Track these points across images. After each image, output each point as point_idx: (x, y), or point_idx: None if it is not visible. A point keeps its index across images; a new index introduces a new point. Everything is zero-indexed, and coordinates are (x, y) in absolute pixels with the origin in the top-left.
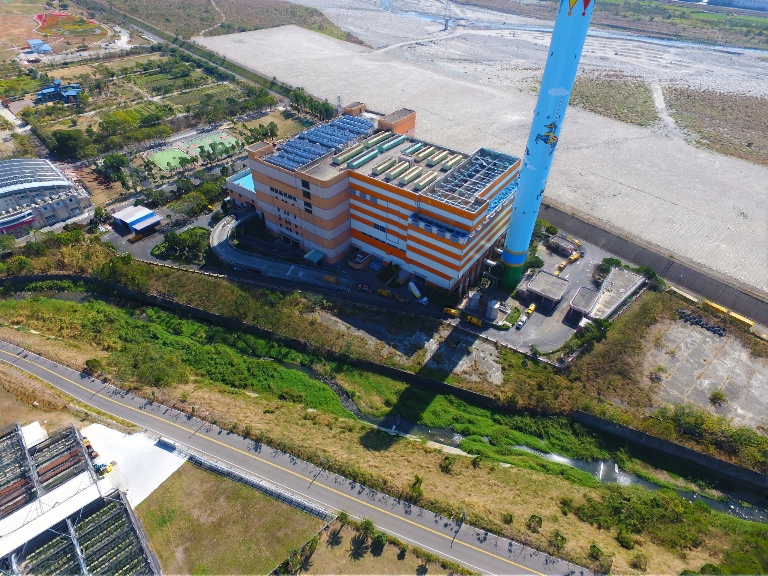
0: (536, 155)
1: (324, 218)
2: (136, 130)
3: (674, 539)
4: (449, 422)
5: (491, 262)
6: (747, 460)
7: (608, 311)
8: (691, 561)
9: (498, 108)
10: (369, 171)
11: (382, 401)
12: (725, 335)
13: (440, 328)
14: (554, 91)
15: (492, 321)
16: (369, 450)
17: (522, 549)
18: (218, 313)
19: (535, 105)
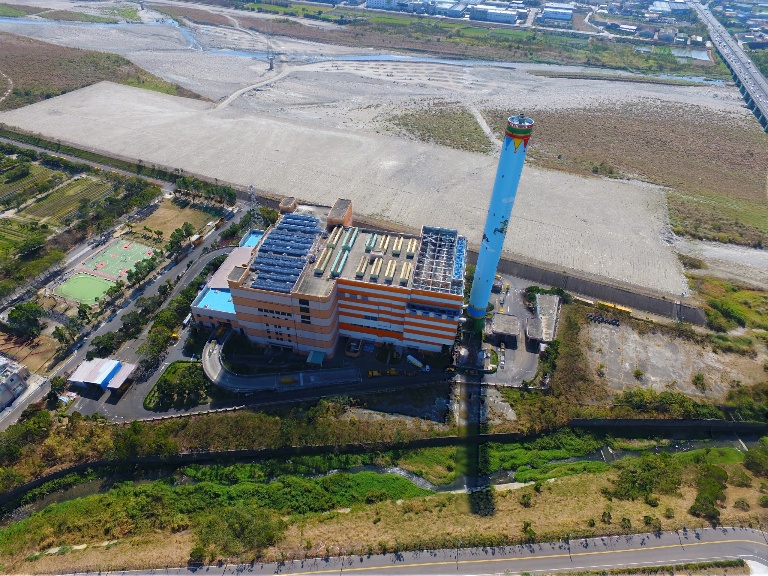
0: (495, 242)
1: (325, 325)
2: (19, 264)
3: (672, 487)
4: (499, 464)
5: (461, 319)
6: (676, 414)
7: (552, 332)
8: (685, 497)
9: (371, 155)
10: (352, 274)
11: (445, 469)
12: (620, 324)
13: (451, 388)
14: (506, 200)
15: (483, 368)
16: (470, 516)
17: (610, 539)
18: (264, 447)
19: (398, 147)
